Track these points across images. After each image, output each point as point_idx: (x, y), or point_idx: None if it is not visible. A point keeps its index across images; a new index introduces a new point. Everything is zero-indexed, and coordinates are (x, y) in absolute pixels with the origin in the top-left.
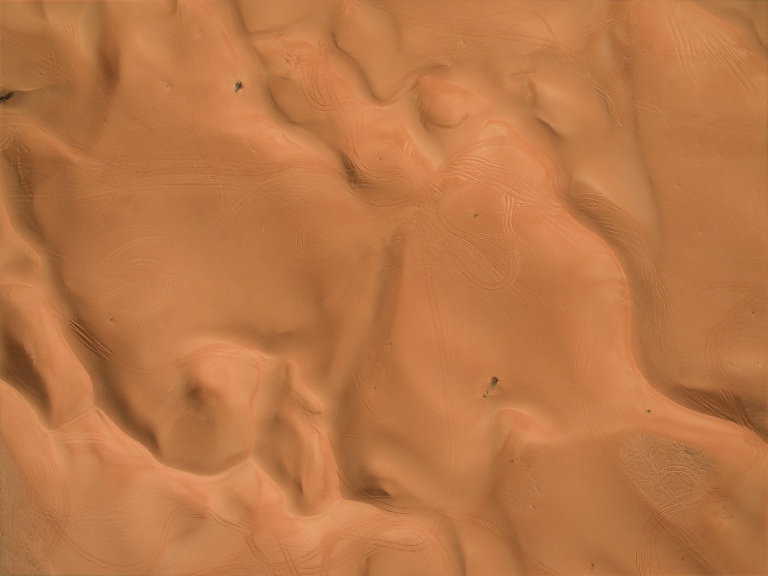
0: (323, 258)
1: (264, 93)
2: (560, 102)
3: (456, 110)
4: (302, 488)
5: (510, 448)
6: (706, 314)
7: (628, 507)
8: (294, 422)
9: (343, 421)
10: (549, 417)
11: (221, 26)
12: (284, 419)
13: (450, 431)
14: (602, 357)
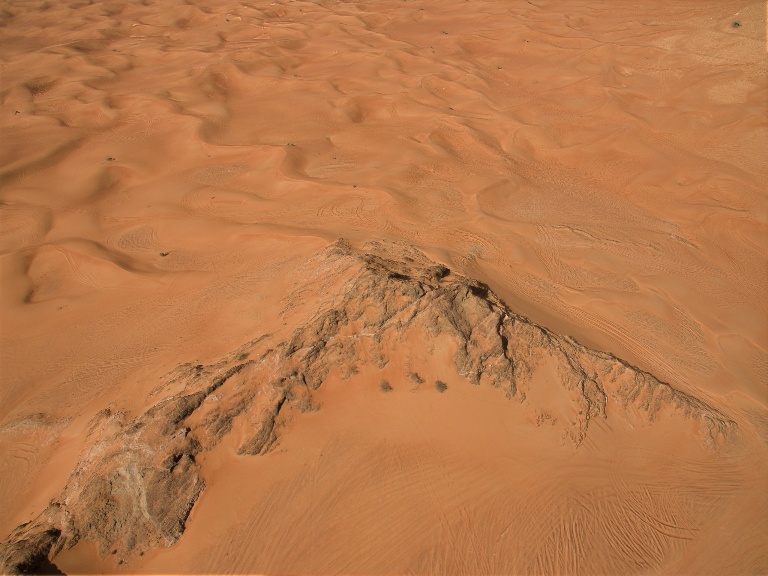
0: None
1: (30, 112)
2: None
3: None
4: None
5: (117, 188)
6: (251, 130)
7: None
8: None
9: None
10: (145, 169)
11: None
12: None
13: None
14: None
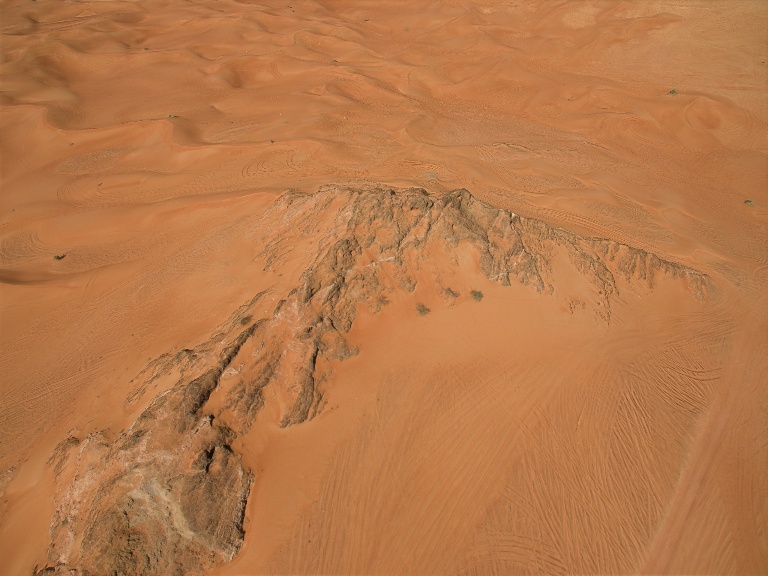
0: None
1: None
2: (6, 85)
3: None
4: None
5: None
6: None
7: (56, 181)
8: None
9: None
10: None
11: None
12: None
13: None
14: (31, 136)
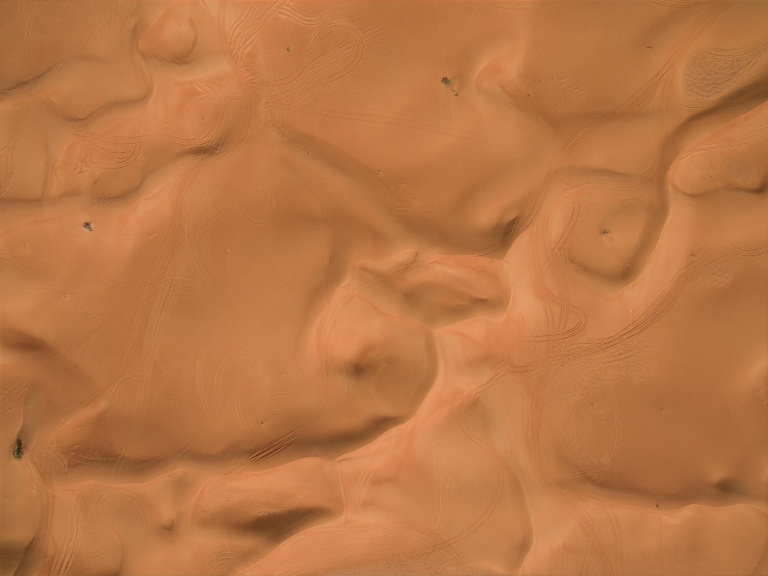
0: (275, 204)
1: (102, 204)
2: None
3: (182, 30)
4: (482, 299)
5: (516, 93)
6: None
7: None
8: (417, 282)
9: (433, 236)
10: (498, 43)
11: (26, 223)
12: (411, 290)
13: (478, 140)
14: None
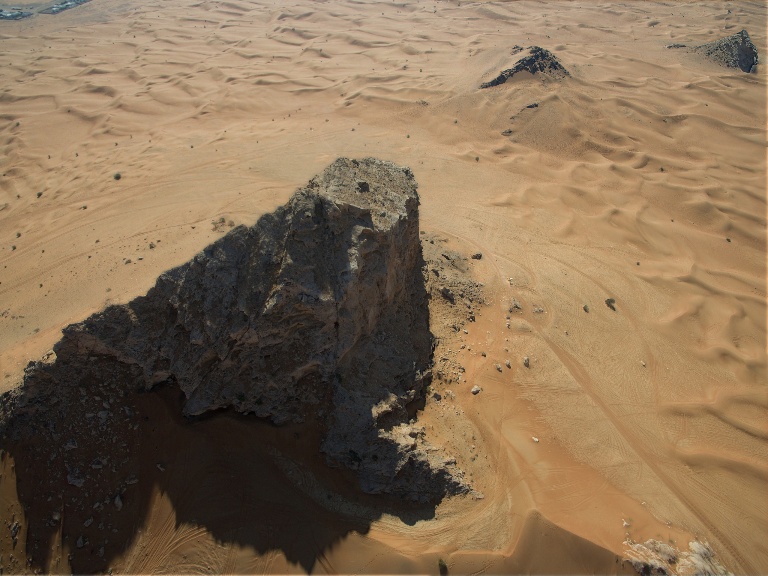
0: None
1: None
2: None
3: None
4: None
5: None
6: None
7: None
8: (714, 87)
9: None
10: None
11: None
12: None
13: None
14: None
